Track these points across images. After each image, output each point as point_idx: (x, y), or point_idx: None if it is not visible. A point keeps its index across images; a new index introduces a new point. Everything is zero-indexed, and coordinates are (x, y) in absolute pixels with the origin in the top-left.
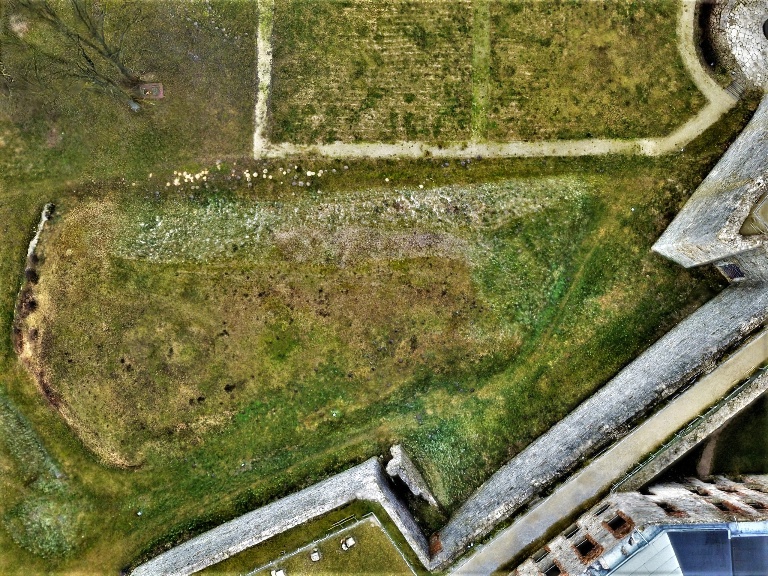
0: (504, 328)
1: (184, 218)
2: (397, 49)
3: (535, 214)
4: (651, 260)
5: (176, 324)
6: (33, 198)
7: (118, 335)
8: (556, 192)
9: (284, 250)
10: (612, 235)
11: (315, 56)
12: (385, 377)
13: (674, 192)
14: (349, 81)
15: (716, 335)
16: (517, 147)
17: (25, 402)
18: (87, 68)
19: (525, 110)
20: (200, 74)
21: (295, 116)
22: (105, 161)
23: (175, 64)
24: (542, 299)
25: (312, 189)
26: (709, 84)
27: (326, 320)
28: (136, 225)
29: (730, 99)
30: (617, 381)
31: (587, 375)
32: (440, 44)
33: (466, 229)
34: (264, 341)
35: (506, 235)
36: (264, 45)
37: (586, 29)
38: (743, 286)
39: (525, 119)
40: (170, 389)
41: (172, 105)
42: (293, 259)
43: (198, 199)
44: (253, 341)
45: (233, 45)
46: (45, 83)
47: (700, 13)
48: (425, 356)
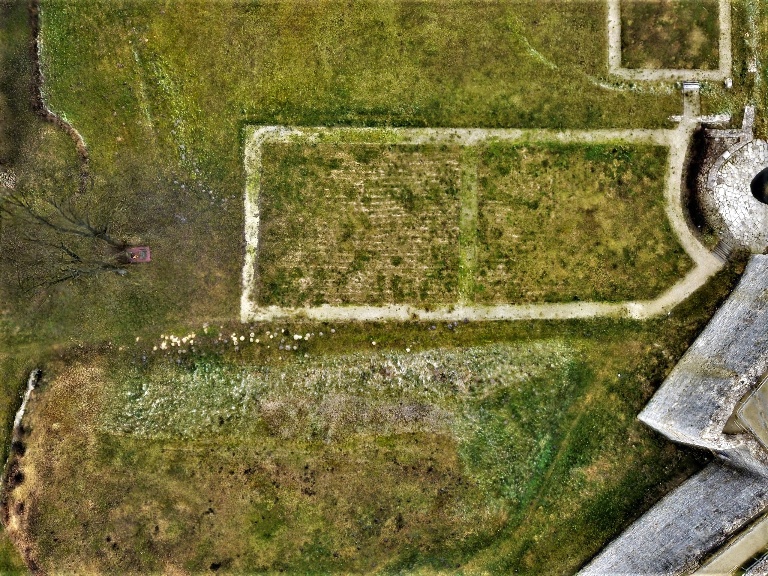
0: (489, 504)
1: (170, 386)
2: (384, 211)
3: (521, 383)
4: (637, 429)
5: (162, 502)
6: (20, 362)
7: (104, 514)
8: (542, 359)
9: (270, 424)
10: (598, 401)
11: (302, 218)
12: (370, 557)
13: (660, 358)
14: (336, 244)
15: (699, 532)
16: (504, 310)
17: (11, 574)
18: (72, 261)
19: (512, 273)
20: (187, 237)
21: (282, 279)
22: (92, 325)
23: (162, 227)
24: (528, 470)
25: (299, 353)
26: (696, 247)
27: (311, 499)
28: (122, 395)
29: (717, 262)
30: (602, 561)
31: (572, 550)
32: (427, 206)
33: (452, 400)
34: (249, 520)
35: (492, 405)
36: (251, 207)
37: (573, 191)
38: (728, 466)
39: (512, 282)
40: (155, 568)
41: (159, 268)
42: (279, 435)
43: (185, 364)
44: (238, 520)
45: (220, 208)
46: (28, 297)
47: (687, 174)
48: (410, 535)
